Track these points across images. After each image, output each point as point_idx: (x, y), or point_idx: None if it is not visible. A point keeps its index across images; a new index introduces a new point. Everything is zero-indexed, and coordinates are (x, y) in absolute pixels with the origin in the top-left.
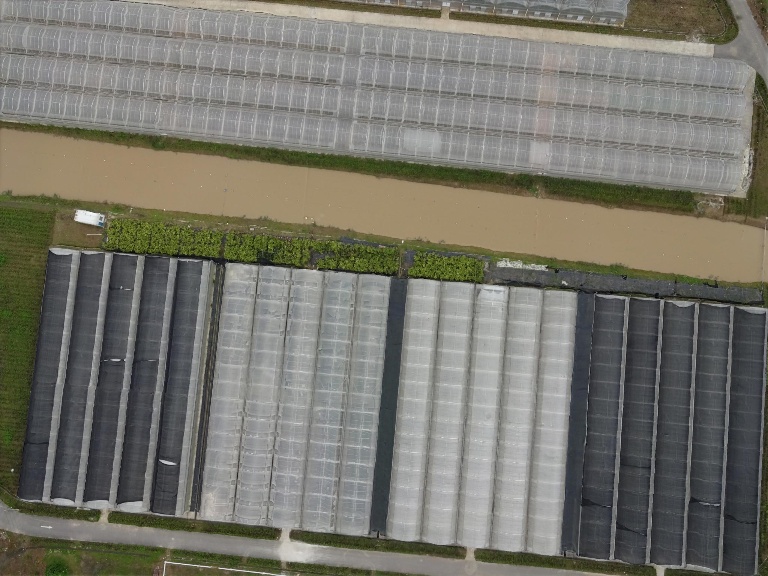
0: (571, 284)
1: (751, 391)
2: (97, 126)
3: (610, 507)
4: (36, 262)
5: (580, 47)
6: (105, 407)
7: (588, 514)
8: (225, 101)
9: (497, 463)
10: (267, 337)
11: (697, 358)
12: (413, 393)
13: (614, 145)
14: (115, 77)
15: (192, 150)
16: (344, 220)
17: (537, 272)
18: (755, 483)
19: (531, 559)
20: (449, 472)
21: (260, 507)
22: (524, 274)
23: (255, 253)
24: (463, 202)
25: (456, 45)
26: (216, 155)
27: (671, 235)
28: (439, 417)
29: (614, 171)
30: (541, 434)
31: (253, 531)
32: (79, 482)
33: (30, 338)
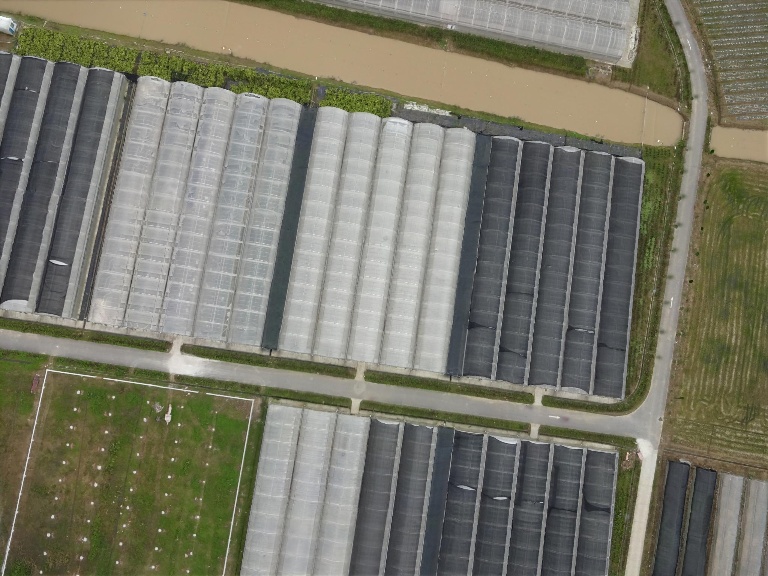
0: (472, 130)
1: (626, 231)
2: None
3: (494, 329)
4: None
5: None
6: None
7: (473, 336)
8: None
9: (391, 285)
10: (174, 151)
11: (581, 201)
12: (314, 211)
13: (517, 6)
14: None
15: None
16: (261, 53)
17: (441, 117)
18: (626, 314)
19: (418, 381)
20: (344, 288)
21: (152, 313)
22: (429, 117)
23: (169, 73)
24: (377, 48)
25: None
26: None
27: (564, 96)
28: (338, 236)
29: (515, 27)
30: (434, 259)
31: (143, 342)
32: None
33: None
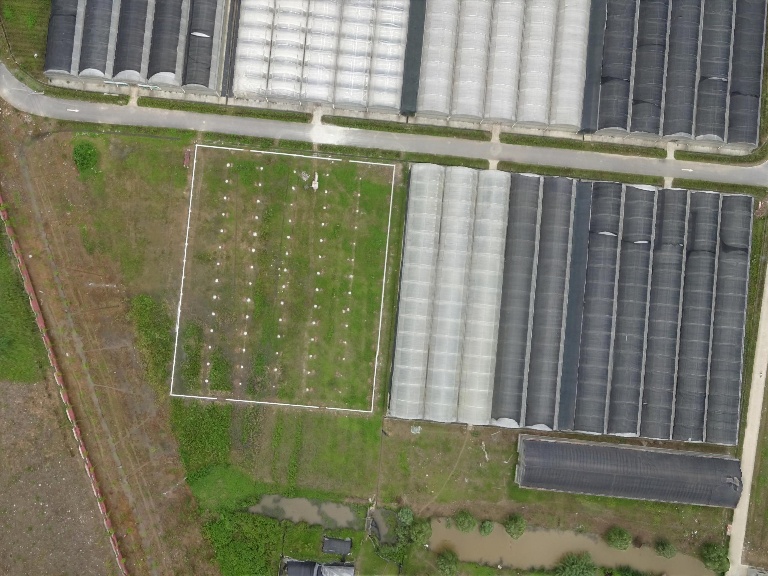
0: None
1: None
2: None
3: (628, 82)
4: None
5: None
6: None
7: (607, 90)
8: None
9: (523, 44)
10: None
11: None
12: None
13: None
14: None
15: None
16: None
17: None
18: (759, 61)
19: (552, 141)
20: (478, 47)
21: (294, 80)
22: None
23: None
24: None
25: None
26: None
27: None
28: None
29: None
30: (565, 15)
31: (285, 114)
32: (109, 56)
33: None
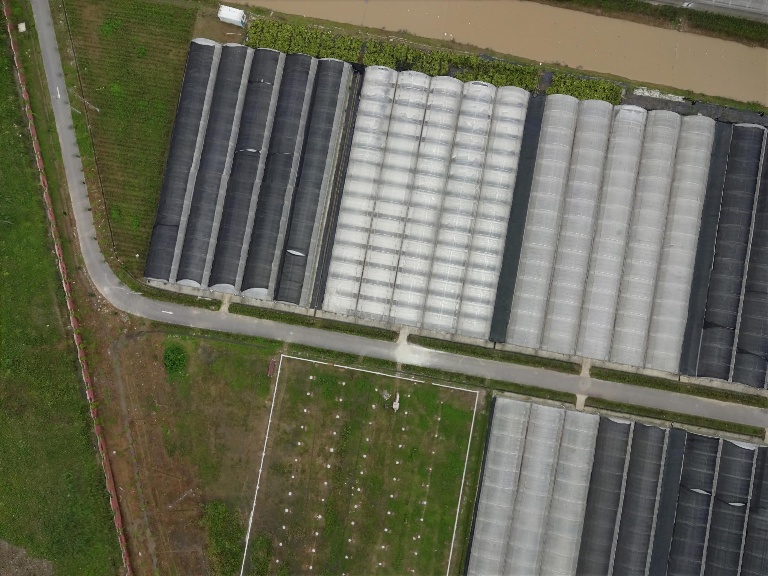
0: None
1: None
2: None
3: (733, 330)
4: (175, 56)
5: None
6: (238, 195)
7: (710, 336)
8: None
9: (622, 281)
10: (401, 142)
11: None
12: (545, 204)
13: None
14: None
15: None
16: (483, 39)
17: (674, 102)
18: None
19: (646, 380)
20: (575, 283)
21: (384, 304)
22: (660, 103)
23: (394, 62)
24: (604, 30)
25: None
26: None
27: None
28: (569, 230)
29: (763, 4)
30: (669, 254)
31: (372, 331)
32: (206, 266)
33: (164, 129)
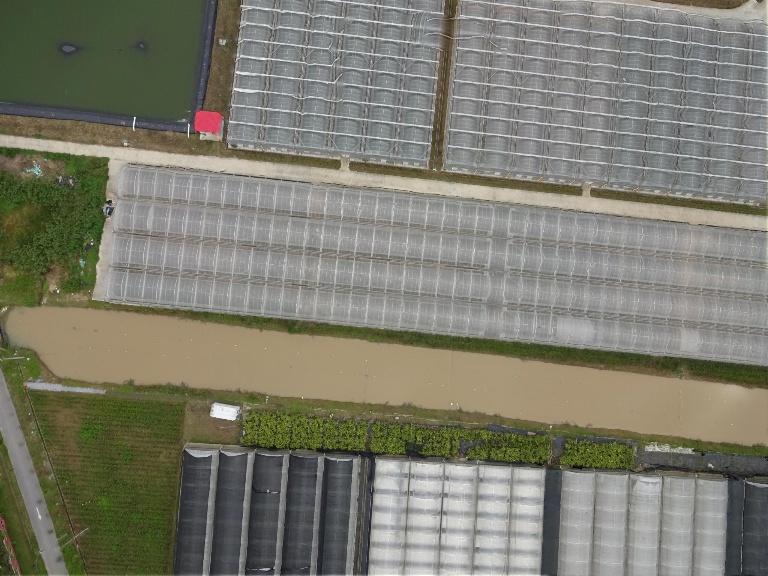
0: (717, 467)
1: None
2: (230, 312)
3: None
4: (166, 458)
5: (725, 232)
6: None
7: None
8: (368, 286)
9: None
10: (421, 536)
11: None
12: None
13: (759, 330)
14: (250, 261)
15: (330, 334)
16: (491, 405)
17: (684, 455)
18: None
19: None
20: None
21: None
22: (672, 458)
23: (403, 445)
24: (608, 384)
25: (606, 231)
26: (355, 338)
27: None
28: None
29: (761, 358)
30: None
31: None
32: None
33: (163, 542)
